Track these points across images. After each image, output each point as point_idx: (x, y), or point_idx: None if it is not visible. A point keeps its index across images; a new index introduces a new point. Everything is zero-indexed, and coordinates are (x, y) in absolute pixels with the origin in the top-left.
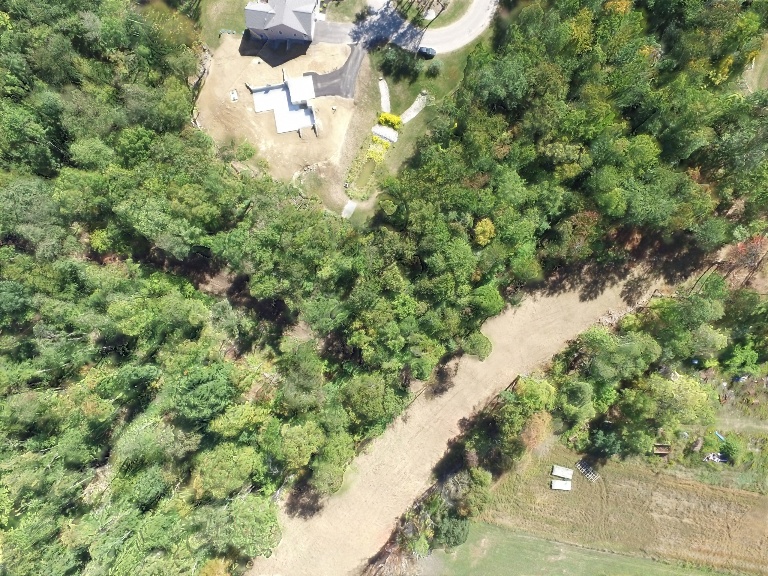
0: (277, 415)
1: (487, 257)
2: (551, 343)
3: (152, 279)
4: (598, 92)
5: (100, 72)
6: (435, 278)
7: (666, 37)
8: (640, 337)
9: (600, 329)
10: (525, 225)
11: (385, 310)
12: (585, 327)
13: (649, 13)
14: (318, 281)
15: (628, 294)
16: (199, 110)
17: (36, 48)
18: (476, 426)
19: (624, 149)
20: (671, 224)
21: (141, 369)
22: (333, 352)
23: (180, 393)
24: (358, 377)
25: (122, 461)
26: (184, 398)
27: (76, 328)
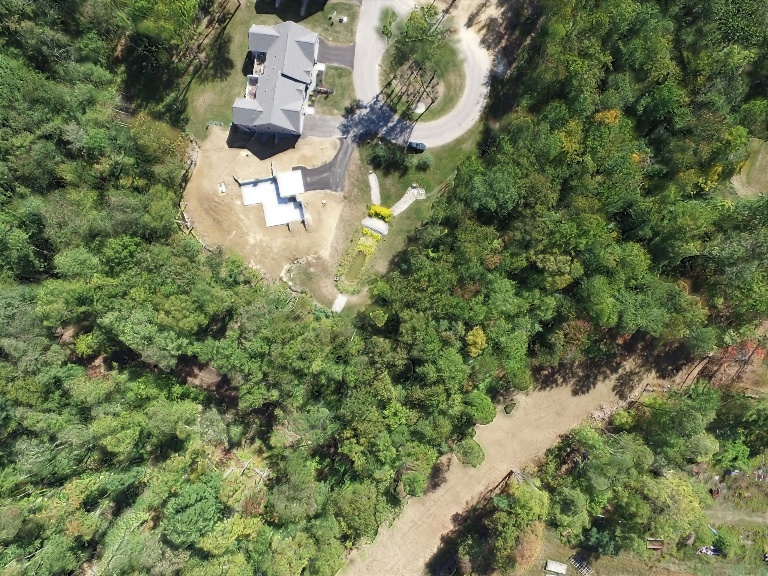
0: (267, 522)
1: (479, 369)
2: (544, 437)
3: (139, 384)
4: (588, 206)
5: (85, 166)
6: (426, 388)
7: (655, 139)
8: (632, 441)
9: (592, 424)
10: (516, 337)
11: (376, 420)
12: (577, 421)
13: (638, 117)
14: (309, 375)
15: (620, 388)
16: (186, 202)
17: (18, 155)
18: (469, 521)
19: (615, 258)
20: (662, 336)
21: (128, 477)
22: (324, 447)
23: (167, 517)
24: (349, 485)
25: (110, 556)
26: (172, 522)
27: (61, 437)
